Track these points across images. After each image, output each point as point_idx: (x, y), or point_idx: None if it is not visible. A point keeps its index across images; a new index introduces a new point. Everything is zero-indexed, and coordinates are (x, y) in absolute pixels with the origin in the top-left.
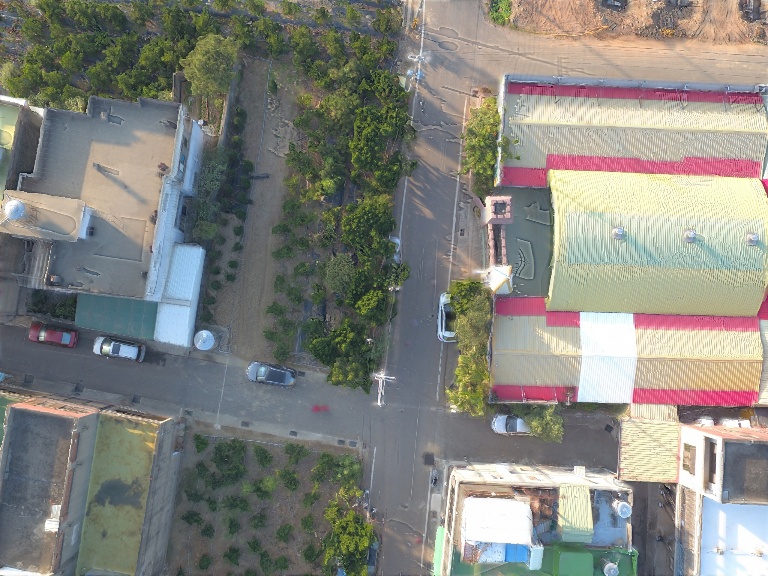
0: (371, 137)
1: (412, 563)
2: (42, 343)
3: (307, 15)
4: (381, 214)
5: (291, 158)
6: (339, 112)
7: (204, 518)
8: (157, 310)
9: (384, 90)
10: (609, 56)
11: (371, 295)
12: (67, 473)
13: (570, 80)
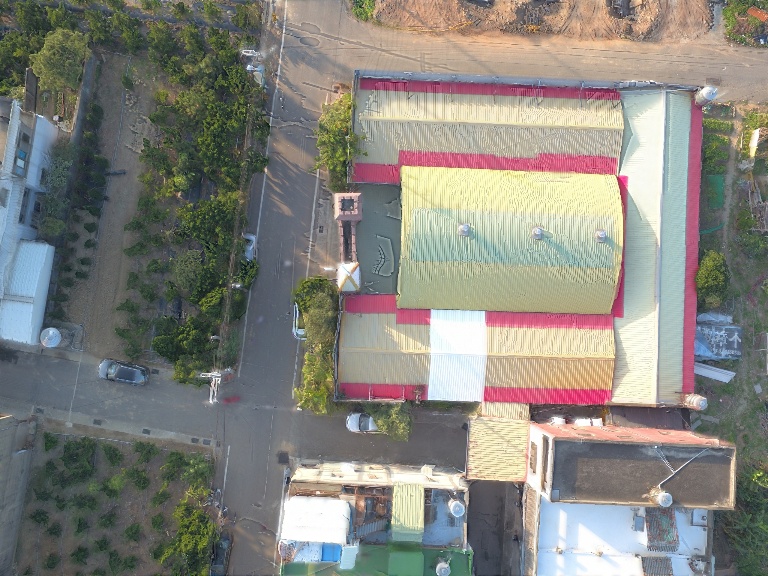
0: (218, 133)
1: (265, 562)
2: None
3: (167, 10)
4: (228, 210)
5: (145, 154)
6: (192, 108)
7: (51, 517)
8: None
9: (237, 86)
10: (473, 52)
11: (215, 292)
12: None
13: (433, 76)
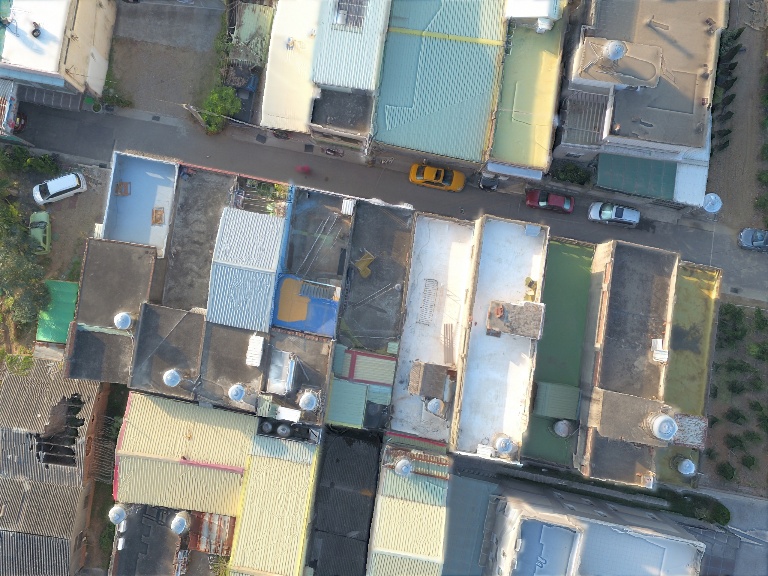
0: None
1: None
2: (541, 208)
3: None
4: None
5: None
6: None
7: None
8: (676, 170)
9: None
10: None
11: None
12: (673, 305)
13: None
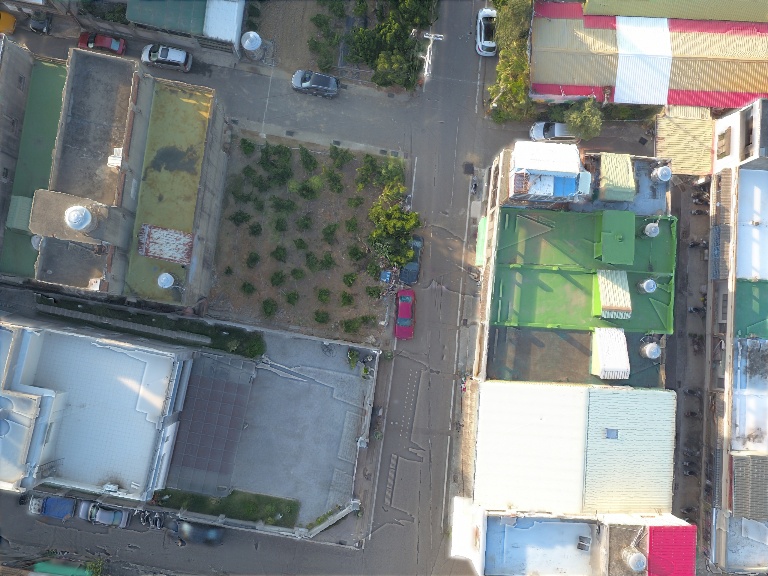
0: None
1: (453, 266)
2: None
3: None
4: None
5: None
6: None
7: None
8: (206, 5)
9: None
10: None
11: None
12: (129, 112)
13: None
